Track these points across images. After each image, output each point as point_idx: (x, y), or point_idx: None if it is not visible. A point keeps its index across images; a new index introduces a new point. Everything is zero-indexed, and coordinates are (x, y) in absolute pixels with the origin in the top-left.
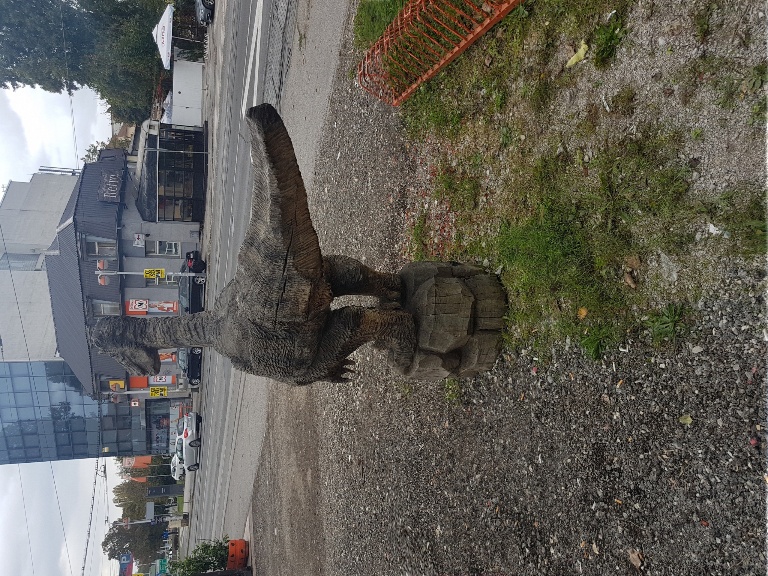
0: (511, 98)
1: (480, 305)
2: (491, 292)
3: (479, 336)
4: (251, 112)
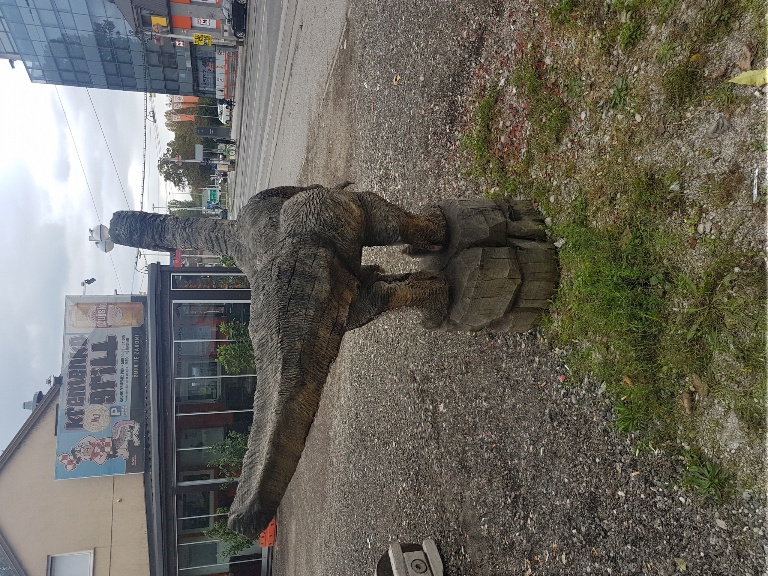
0: (643, 45)
1: (526, 287)
2: (543, 271)
3: (516, 314)
4: (234, 522)
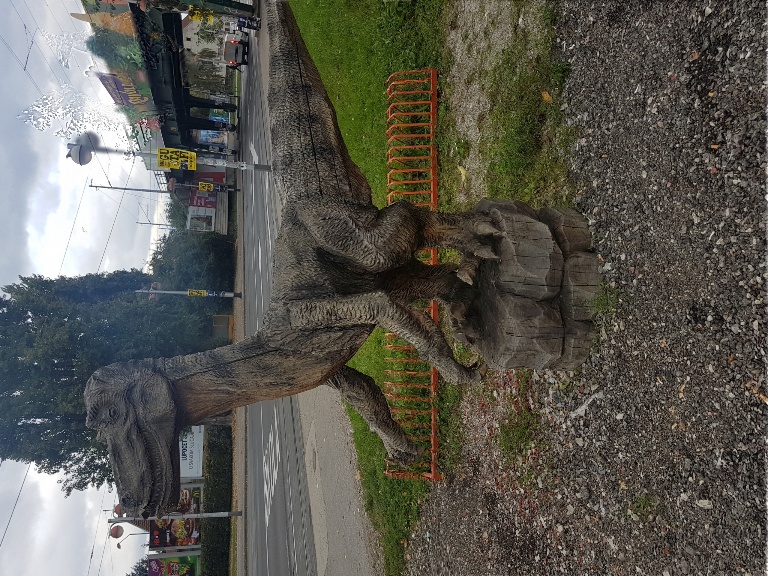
0: None
1: None
2: None
3: None
4: None
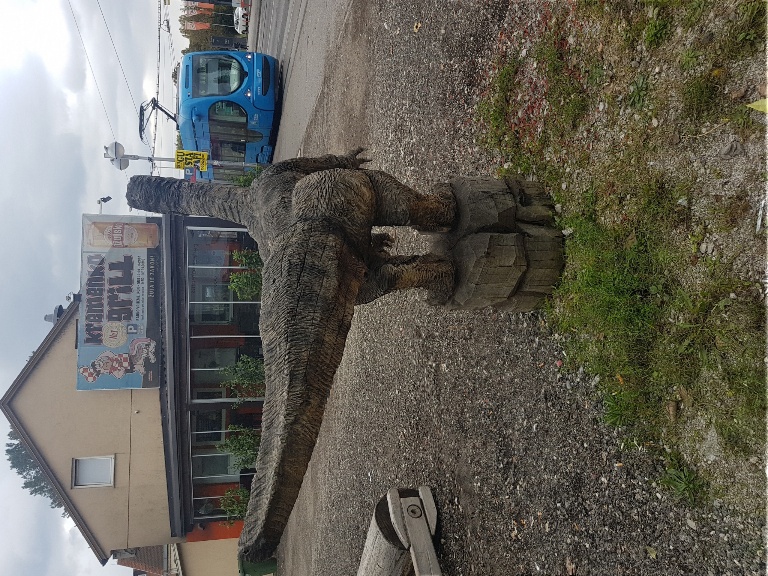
0: (668, 46)
1: (531, 273)
2: (548, 259)
3: (520, 298)
4: None
